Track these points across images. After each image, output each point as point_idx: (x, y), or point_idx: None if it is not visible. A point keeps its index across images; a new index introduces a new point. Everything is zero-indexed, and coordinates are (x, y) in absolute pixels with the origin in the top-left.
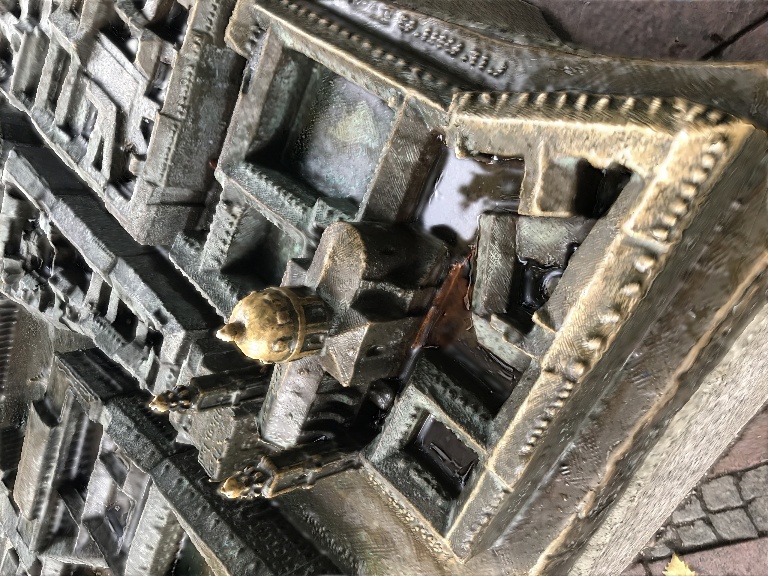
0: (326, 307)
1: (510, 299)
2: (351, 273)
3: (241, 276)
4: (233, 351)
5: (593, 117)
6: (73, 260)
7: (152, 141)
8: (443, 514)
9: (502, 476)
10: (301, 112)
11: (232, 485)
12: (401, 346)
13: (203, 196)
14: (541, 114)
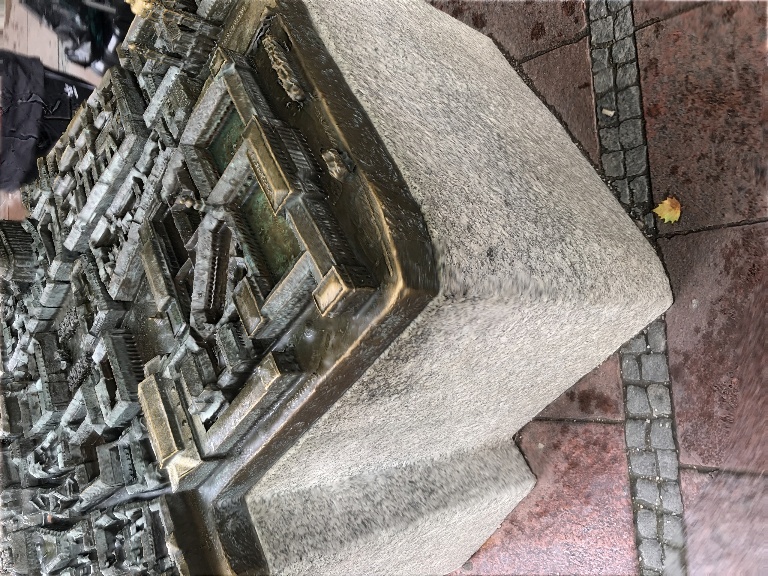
0: None
1: None
2: None
3: None
4: None
5: None
6: None
7: (119, 108)
8: None
9: None
10: None
11: None
12: (191, 2)
13: None
14: None
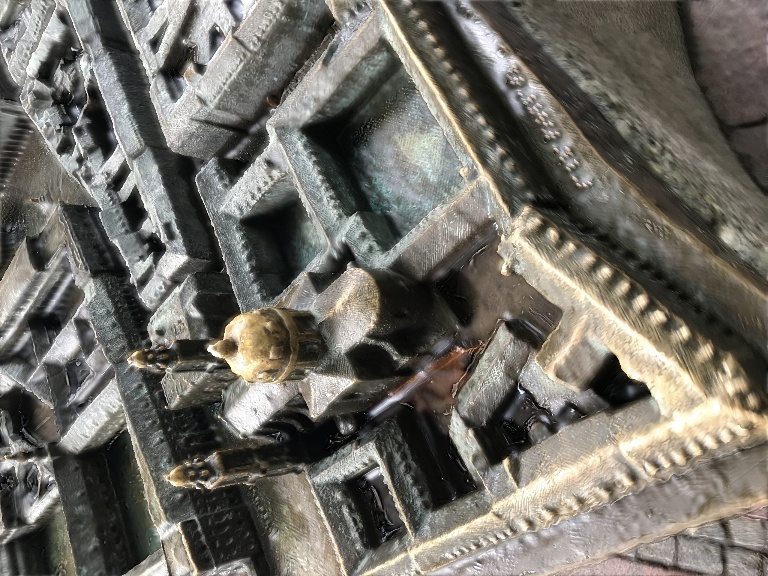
0: (322, 345)
1: (494, 415)
2: (357, 327)
3: (258, 231)
4: (227, 294)
5: (644, 329)
6: (103, 115)
7: (216, 59)
8: (357, 558)
9: (419, 563)
10: (375, 100)
11: (178, 477)
12: (379, 393)
13: (250, 125)
14: (597, 292)
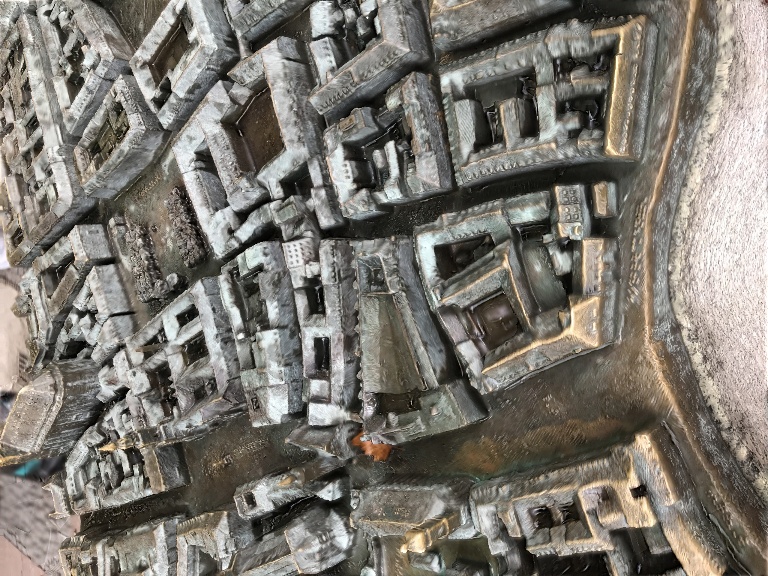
0: None
1: None
2: None
3: None
4: None
5: None
6: None
7: (4, 49)
8: None
9: None
10: None
11: None
12: None
13: None
14: None
